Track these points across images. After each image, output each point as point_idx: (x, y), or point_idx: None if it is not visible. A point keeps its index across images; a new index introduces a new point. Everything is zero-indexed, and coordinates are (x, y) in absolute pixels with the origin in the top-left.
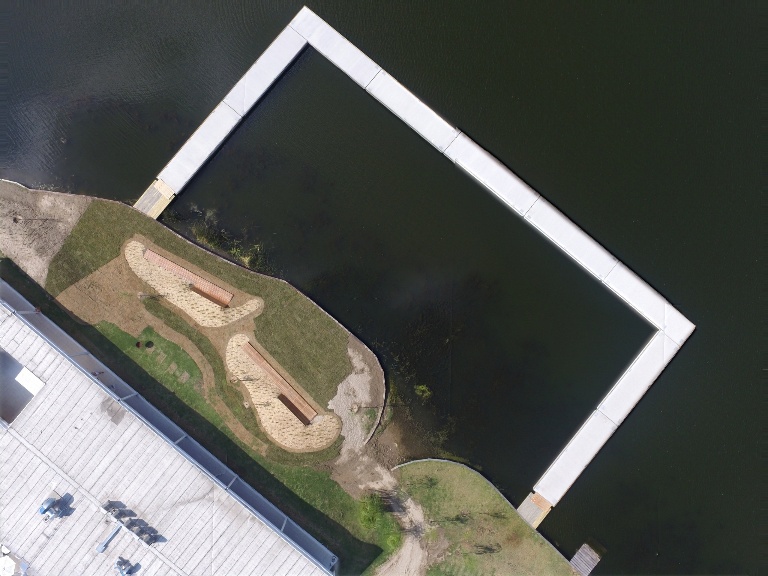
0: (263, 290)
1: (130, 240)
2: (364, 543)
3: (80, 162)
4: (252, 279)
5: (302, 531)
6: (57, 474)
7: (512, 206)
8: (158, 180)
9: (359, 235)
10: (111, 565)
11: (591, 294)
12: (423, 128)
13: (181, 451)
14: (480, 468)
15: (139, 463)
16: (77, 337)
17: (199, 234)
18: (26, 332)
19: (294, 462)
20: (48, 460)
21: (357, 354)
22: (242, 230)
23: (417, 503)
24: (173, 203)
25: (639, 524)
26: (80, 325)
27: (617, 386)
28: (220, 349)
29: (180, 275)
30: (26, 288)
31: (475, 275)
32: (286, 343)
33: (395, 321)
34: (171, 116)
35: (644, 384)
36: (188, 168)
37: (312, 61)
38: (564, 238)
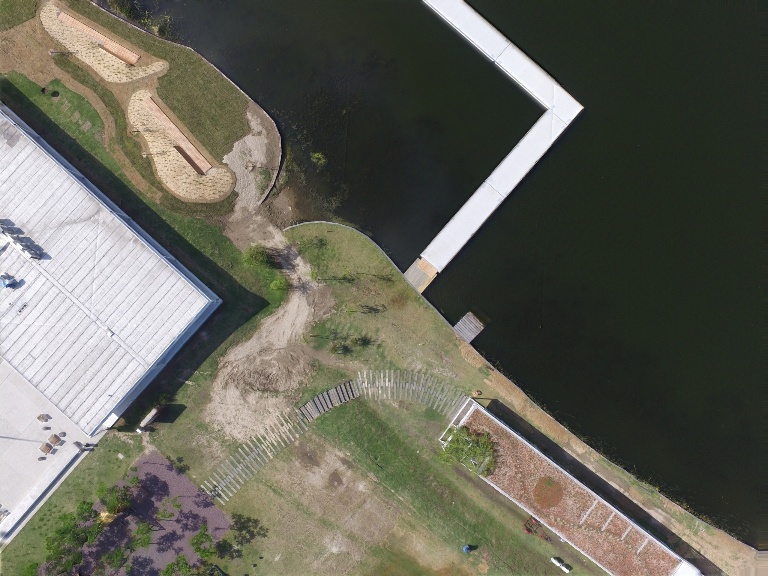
0: (169, 54)
1: (46, 4)
2: (251, 293)
3: None
4: (160, 45)
5: (189, 273)
6: None
7: None
8: None
9: (265, 11)
10: None
11: (484, 75)
12: None
13: (71, 174)
14: (370, 234)
15: (30, 184)
16: None
17: (112, 1)
18: None
19: (187, 212)
20: None
21: (256, 118)
22: (154, 2)
23: (306, 261)
24: None
25: (524, 297)
26: None
27: (505, 160)
28: (123, 103)
29: (91, 36)
30: None
31: (373, 52)
32: (187, 101)
33: (295, 92)
34: None
35: (532, 160)
36: None
37: None
38: (459, 19)
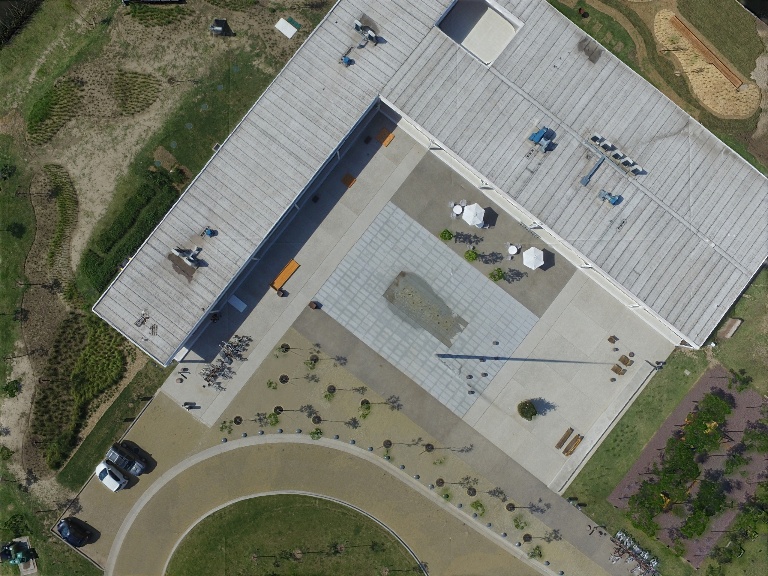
0: None
1: None
2: None
3: None
4: None
5: None
6: (539, 111)
7: None
8: None
9: None
10: (594, 198)
11: None
12: None
13: None
14: None
15: (618, 99)
16: None
17: None
18: None
19: (722, 129)
20: (530, 97)
21: (765, 36)
22: None
23: None
24: None
25: None
26: None
27: None
28: (648, 23)
29: None
30: None
31: None
32: (707, 19)
33: None
34: None
35: None
36: None
37: None
38: None
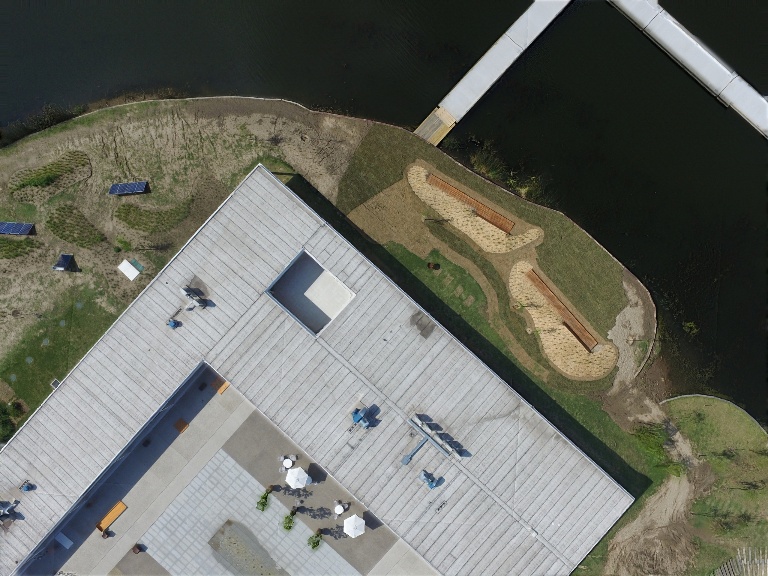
0: (542, 220)
1: (412, 165)
2: (638, 473)
3: (359, 87)
4: (531, 209)
5: None
6: (364, 385)
7: None
8: (440, 108)
9: (632, 172)
10: (414, 478)
11: None
12: (700, 71)
13: None
14: (743, 406)
15: (447, 377)
16: (367, 255)
17: (480, 162)
18: (338, 243)
19: (573, 390)
20: (356, 371)
21: (631, 288)
22: (519, 161)
23: (685, 437)
24: None
25: None
26: (371, 244)
27: None
28: (503, 275)
29: (462, 201)
30: (318, 204)
31: (745, 217)
32: (567, 273)
33: (665, 258)
34: (451, 46)
35: None
36: (469, 97)
37: (589, 1)
38: None
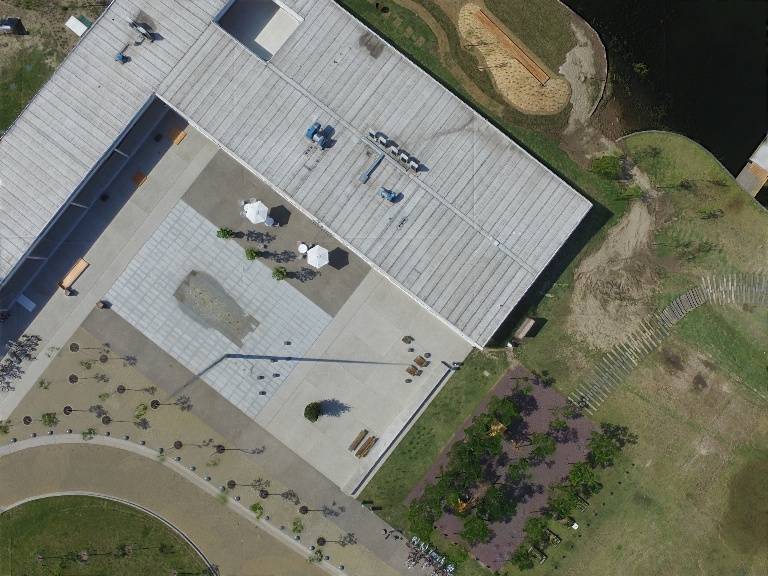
0: None
1: None
2: (598, 203)
3: None
4: None
5: None
6: (318, 107)
7: None
8: None
9: None
10: (373, 196)
11: None
12: None
13: None
14: (698, 142)
15: (399, 95)
16: None
17: None
18: None
19: (528, 125)
20: (308, 93)
21: (580, 29)
22: None
23: (643, 171)
24: None
25: None
26: None
27: None
28: (452, 17)
29: None
30: None
31: None
32: (515, 13)
33: (611, 3)
34: None
35: None
36: None
37: None
38: None
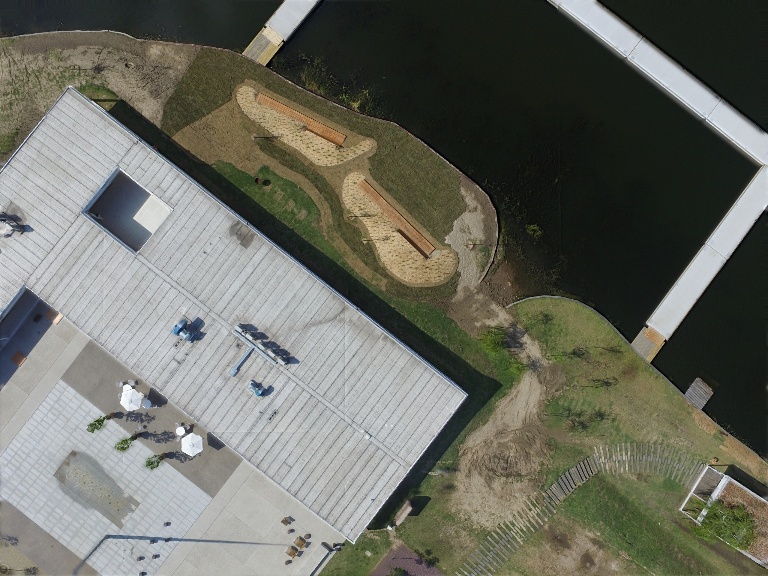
0: (375, 132)
1: (241, 85)
2: (485, 376)
3: (186, 13)
4: (363, 122)
5: None
6: (187, 299)
7: (616, 48)
8: (267, 27)
9: (466, 79)
10: (243, 389)
11: (695, 133)
12: None
13: (311, 273)
14: (593, 305)
15: (270, 286)
16: (195, 175)
17: (309, 79)
18: (152, 159)
19: (413, 297)
20: (178, 285)
21: (469, 193)
22: (351, 76)
23: (533, 339)
24: (280, 52)
25: (749, 358)
26: (197, 163)
27: (724, 220)
28: (336, 187)
29: (293, 118)
30: (142, 128)
31: (581, 116)
32: (401, 181)
33: (504, 163)
34: None
35: (750, 219)
36: (296, 15)
37: None
38: (668, 77)
